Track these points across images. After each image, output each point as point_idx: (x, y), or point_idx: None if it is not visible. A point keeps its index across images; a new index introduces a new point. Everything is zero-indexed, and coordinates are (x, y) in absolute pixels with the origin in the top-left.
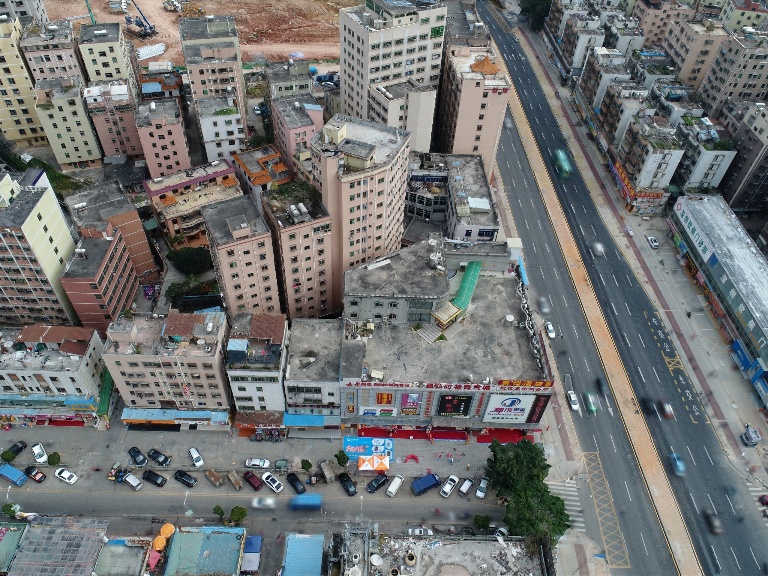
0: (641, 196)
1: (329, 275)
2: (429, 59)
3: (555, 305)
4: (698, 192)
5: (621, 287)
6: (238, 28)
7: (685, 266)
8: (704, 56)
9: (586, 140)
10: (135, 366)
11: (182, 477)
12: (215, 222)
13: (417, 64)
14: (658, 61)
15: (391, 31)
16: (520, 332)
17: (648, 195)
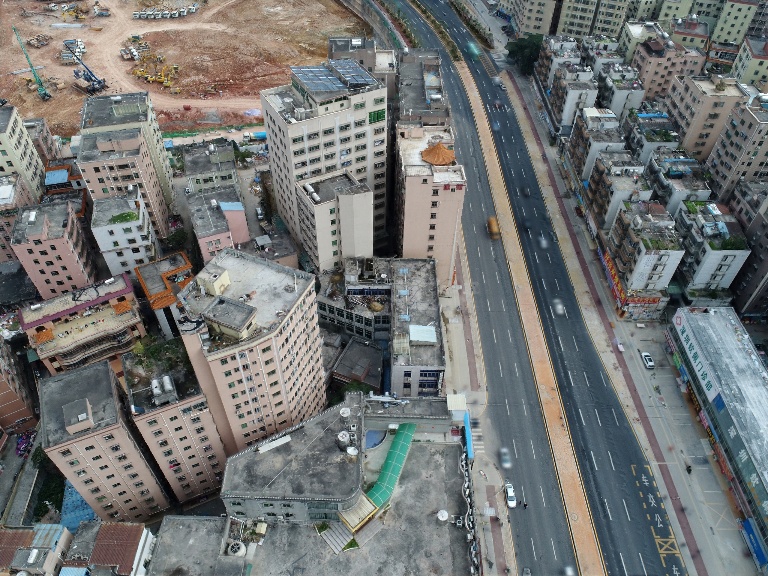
0: (633, 301)
1: (219, 448)
2: (370, 146)
3: (520, 456)
4: (704, 296)
5: (604, 428)
6: (197, 78)
7: (687, 394)
8: (713, 120)
9: (574, 217)
10: None
11: None
12: (54, 404)
13: (355, 153)
14: (658, 124)
15: (316, 121)
16: (457, 533)
17: (642, 300)
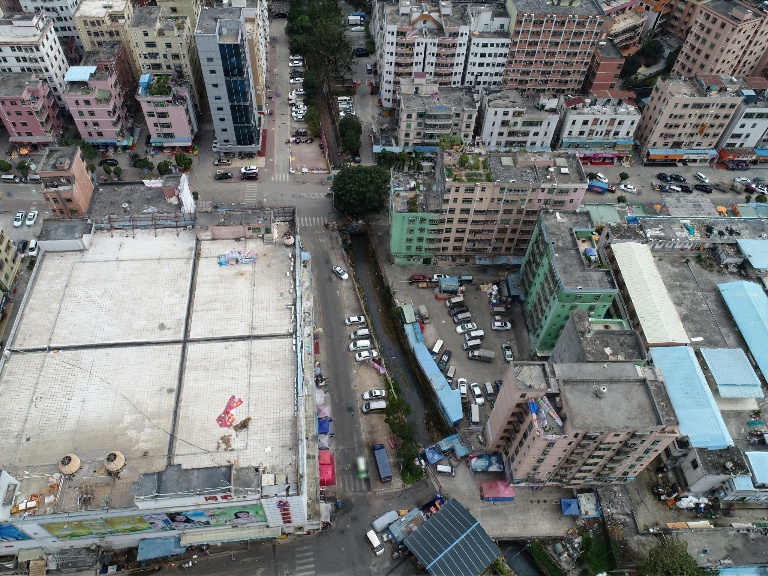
0: None
1: (758, 61)
2: None
3: None
4: None
5: None
6: None
7: None
8: None
9: None
10: (685, 108)
11: (704, 186)
12: None
13: None
14: None
15: None
16: None
17: None
